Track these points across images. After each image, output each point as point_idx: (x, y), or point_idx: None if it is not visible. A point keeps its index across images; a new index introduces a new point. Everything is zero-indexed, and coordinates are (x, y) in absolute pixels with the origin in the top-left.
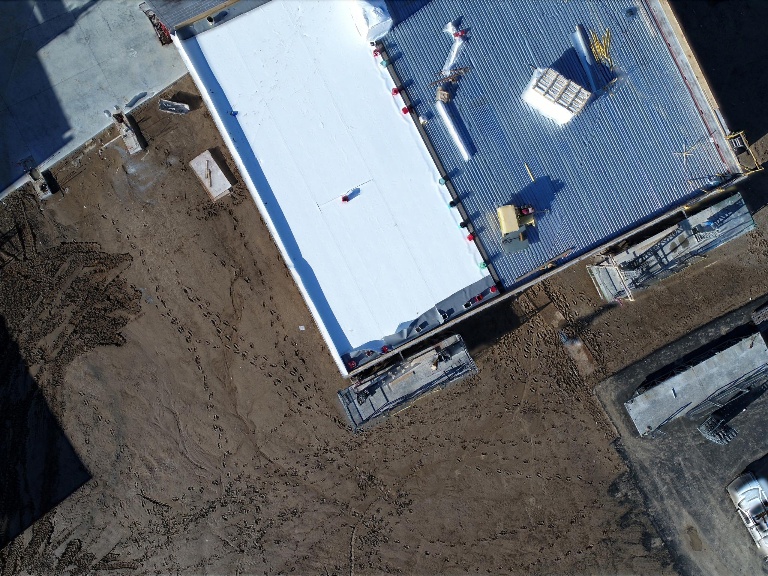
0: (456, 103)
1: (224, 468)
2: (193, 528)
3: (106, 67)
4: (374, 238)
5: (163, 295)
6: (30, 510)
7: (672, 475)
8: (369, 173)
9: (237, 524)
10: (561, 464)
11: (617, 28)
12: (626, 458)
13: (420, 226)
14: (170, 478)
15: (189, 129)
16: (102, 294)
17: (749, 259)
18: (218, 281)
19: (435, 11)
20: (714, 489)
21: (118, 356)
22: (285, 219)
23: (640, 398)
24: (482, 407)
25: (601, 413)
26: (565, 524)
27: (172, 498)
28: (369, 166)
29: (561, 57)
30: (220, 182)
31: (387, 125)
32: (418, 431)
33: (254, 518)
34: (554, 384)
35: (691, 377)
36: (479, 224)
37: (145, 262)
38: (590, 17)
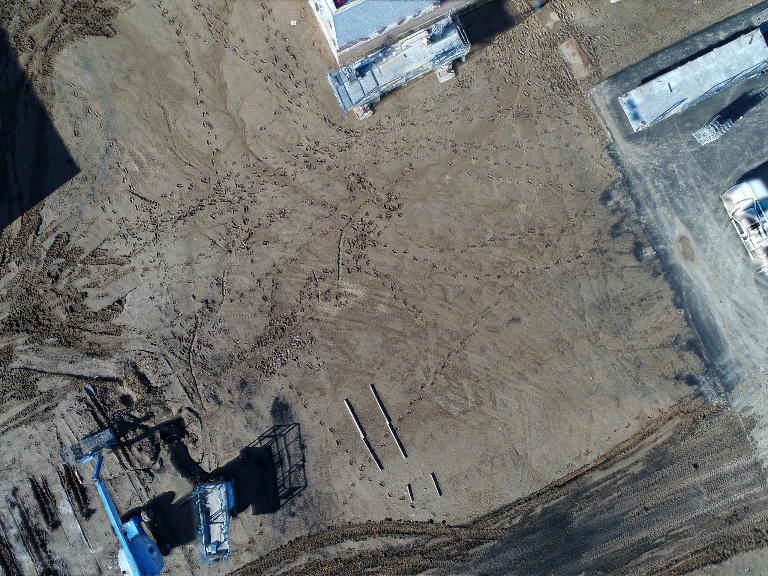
0: None
1: (213, 166)
2: (181, 226)
3: None
4: None
5: None
6: (19, 201)
7: (665, 182)
8: None
9: (225, 223)
10: (553, 171)
11: None
12: (619, 163)
13: None
14: (159, 174)
15: None
16: None
17: None
18: None
19: None
20: (708, 197)
21: (108, 48)
22: None
23: (635, 92)
24: (474, 110)
25: (595, 117)
26: (555, 232)
27: (160, 195)
28: None
29: None
30: None
31: None
32: (409, 133)
33: (242, 218)
34: (548, 88)
35: (687, 72)
36: None
37: None
38: None
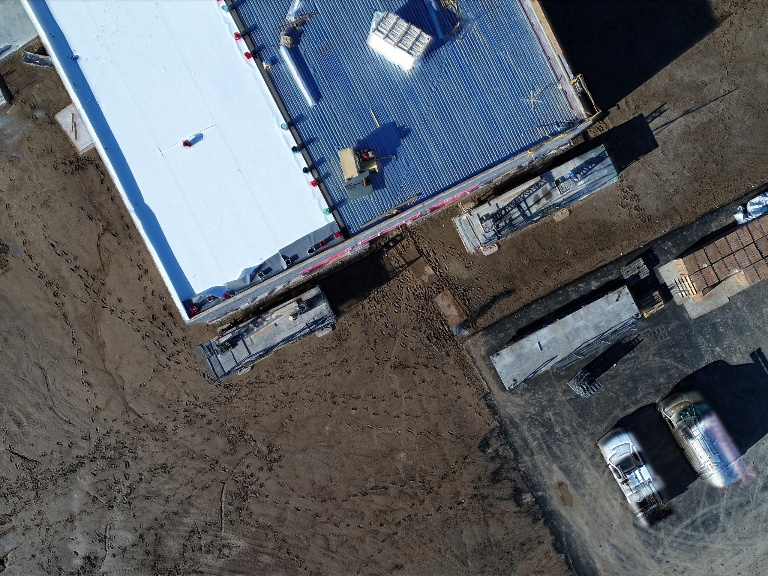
0: (301, 48)
1: (93, 423)
2: (62, 483)
3: None
4: (217, 183)
5: (30, 249)
6: None
7: (542, 430)
8: (212, 118)
9: (106, 479)
10: (432, 419)
11: None
12: (496, 413)
13: (264, 171)
14: (38, 433)
15: (55, 82)
16: None
17: (620, 214)
18: (85, 235)
19: None
20: (585, 444)
21: None
22: (127, 164)
23: (506, 351)
24: (352, 362)
25: (471, 368)
26: (436, 480)
27: (40, 453)
28: (212, 111)
29: (407, 2)
30: (86, 135)
31: (230, 70)
32: (288, 386)
33: (123, 473)
34: (424, 339)
35: (557, 330)
36: (324, 170)
37: (11, 216)
38: None
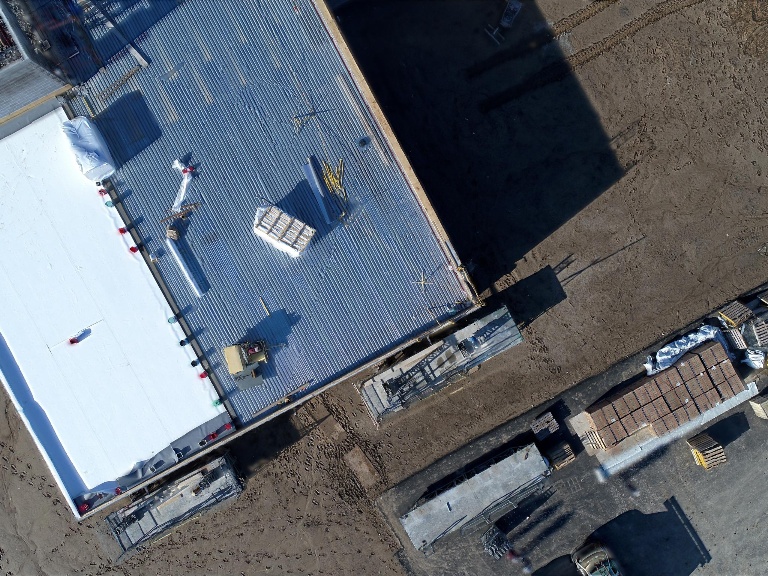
0: (188, 239)
1: None
2: None
3: None
4: (107, 378)
5: None
6: None
7: None
8: (99, 313)
9: None
10: (346, 575)
11: (351, 158)
12: (410, 569)
13: (153, 365)
14: None
15: None
16: None
17: (530, 366)
18: None
19: (164, 147)
20: None
21: None
22: (15, 362)
23: (415, 513)
24: (265, 521)
25: (384, 524)
26: None
27: None
28: (99, 306)
29: (294, 189)
30: None
31: (117, 264)
32: (201, 547)
33: None
34: (336, 496)
35: (466, 490)
36: (215, 360)
37: None
38: (323, 148)
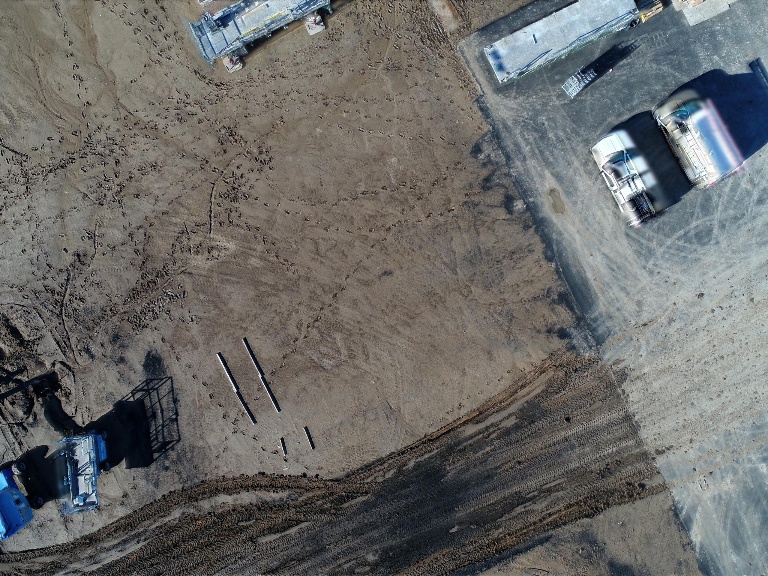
0: None
1: (84, 119)
2: (52, 179)
3: None
4: None
5: None
6: None
7: (535, 135)
8: None
9: (96, 177)
10: (424, 124)
11: None
12: (489, 116)
13: None
14: (29, 127)
15: None
16: None
17: None
18: None
19: None
20: (578, 150)
21: None
22: None
23: (500, 43)
24: (345, 63)
25: (465, 70)
26: (427, 186)
27: (31, 148)
28: None
29: None
30: None
31: None
32: (279, 86)
33: (113, 171)
34: (418, 41)
35: (552, 23)
36: None
37: None
38: None
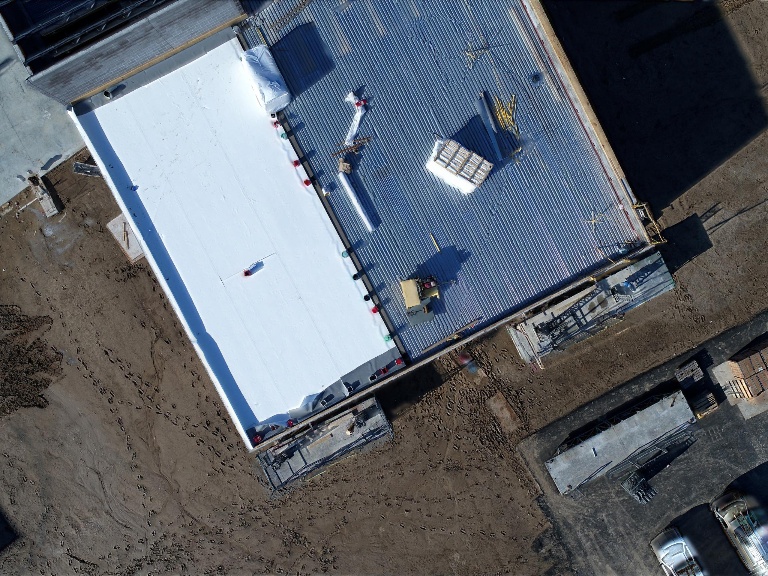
0: (360, 174)
1: (149, 527)
2: None
3: (20, 130)
4: (278, 311)
5: (84, 357)
6: None
7: (595, 531)
8: (272, 246)
9: None
10: (485, 520)
11: (524, 94)
12: (549, 514)
13: (324, 299)
14: (96, 537)
15: (106, 191)
16: (23, 357)
17: (673, 314)
18: (139, 342)
19: (337, 80)
20: (638, 544)
21: (41, 418)
22: (188, 294)
23: (560, 457)
24: (405, 465)
25: (524, 470)
26: None
27: (98, 557)
28: (272, 239)
29: (467, 125)
30: None
31: (290, 197)
32: (341, 489)
33: (180, 575)
34: (477, 441)
35: (612, 436)
36: (385, 295)
37: (65, 324)
38: (496, 83)
